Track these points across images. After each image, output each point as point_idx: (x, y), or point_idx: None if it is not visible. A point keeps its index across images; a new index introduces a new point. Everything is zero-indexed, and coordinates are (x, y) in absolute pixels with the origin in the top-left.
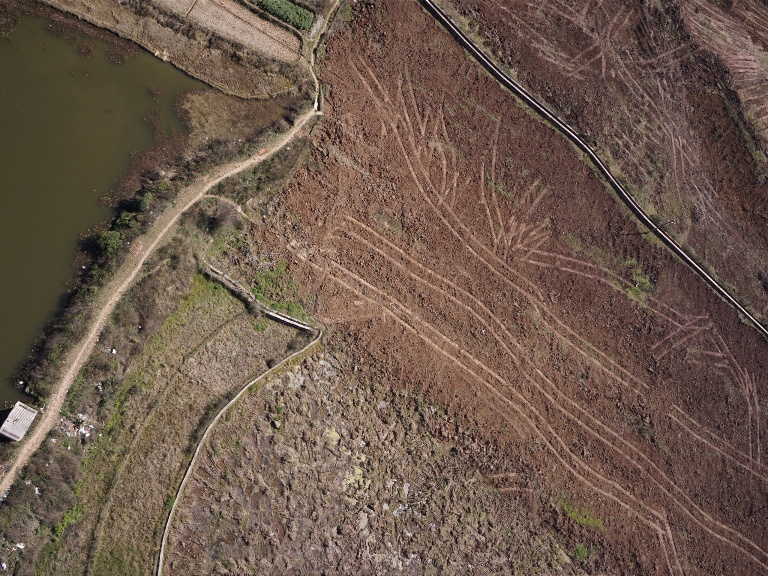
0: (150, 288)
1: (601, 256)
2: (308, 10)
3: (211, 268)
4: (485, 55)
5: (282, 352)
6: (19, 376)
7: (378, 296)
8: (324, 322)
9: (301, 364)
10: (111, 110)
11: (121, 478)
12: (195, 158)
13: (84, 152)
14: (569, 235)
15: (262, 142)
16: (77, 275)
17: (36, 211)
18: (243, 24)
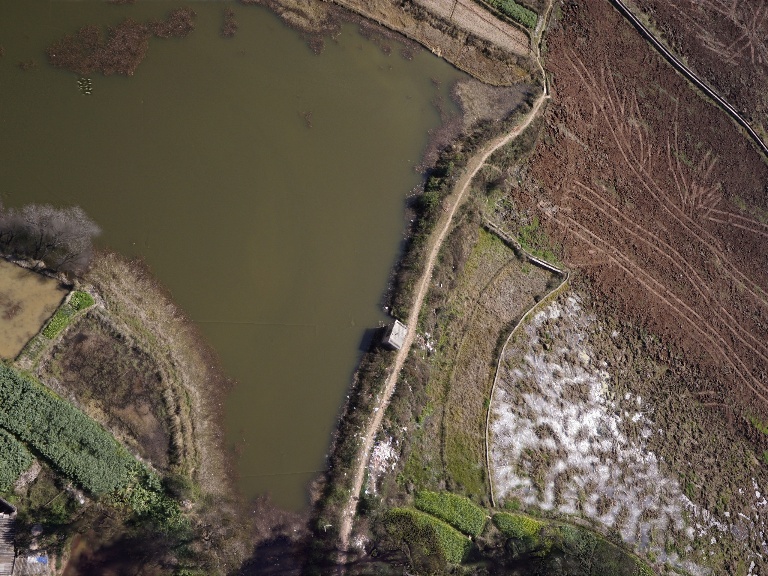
0: (458, 237)
1: (761, 214)
2: (533, 12)
3: (489, 223)
4: (663, 46)
5: (543, 290)
6: (384, 303)
7: (604, 246)
8: (569, 266)
9: (556, 300)
10: (410, 97)
11: (453, 384)
12: (473, 134)
13: (398, 130)
14: (736, 197)
15: (514, 121)
16: (408, 226)
17: (375, 177)
18: (488, 25)
